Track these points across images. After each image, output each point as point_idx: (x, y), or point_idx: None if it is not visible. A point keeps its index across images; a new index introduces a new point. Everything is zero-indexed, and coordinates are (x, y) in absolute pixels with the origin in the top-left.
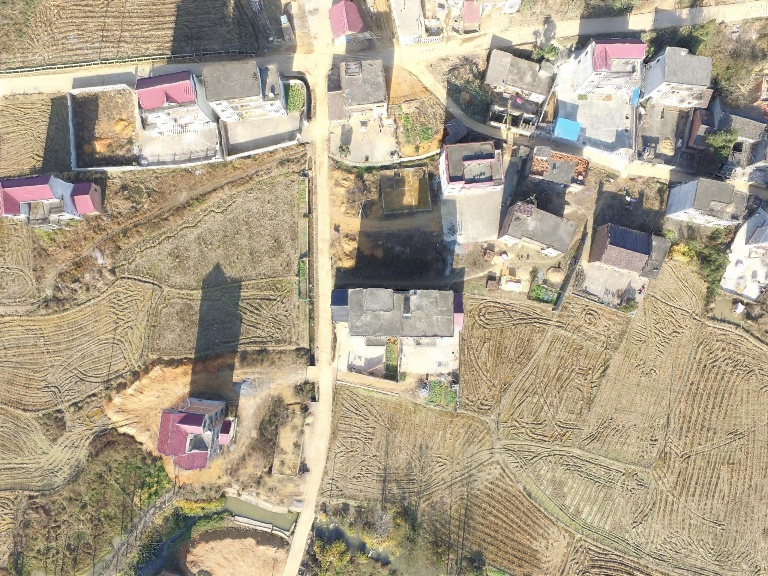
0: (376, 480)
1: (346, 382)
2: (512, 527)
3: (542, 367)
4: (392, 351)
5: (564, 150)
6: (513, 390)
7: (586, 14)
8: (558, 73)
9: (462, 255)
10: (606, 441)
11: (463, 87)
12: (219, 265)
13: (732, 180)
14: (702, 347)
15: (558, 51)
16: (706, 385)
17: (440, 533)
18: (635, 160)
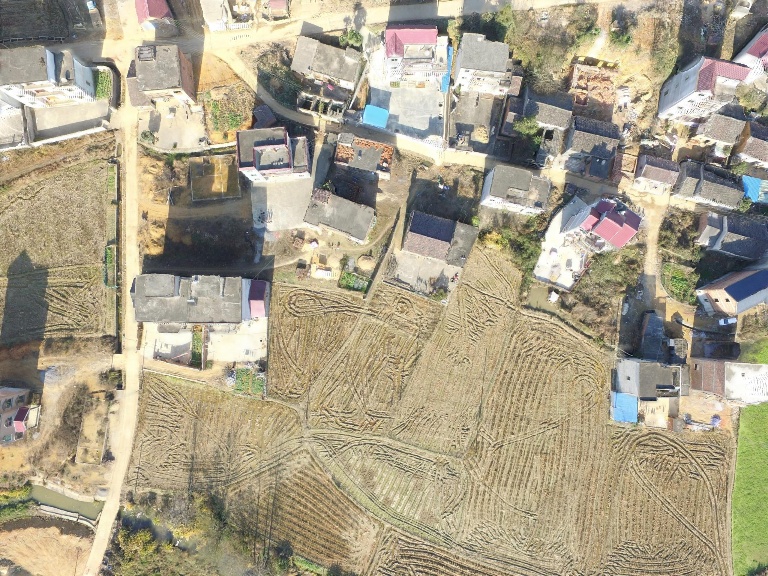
0: (183, 469)
1: (152, 370)
2: (321, 517)
3: (353, 355)
4: (199, 339)
5: (377, 137)
6: (323, 379)
7: (395, 1)
8: (368, 60)
9: (272, 243)
10: (417, 430)
11: (266, 73)
12: (25, 252)
13: (549, 168)
14: (516, 336)
15: (370, 38)
16: (520, 374)
17: (247, 522)
18: (447, 148)
